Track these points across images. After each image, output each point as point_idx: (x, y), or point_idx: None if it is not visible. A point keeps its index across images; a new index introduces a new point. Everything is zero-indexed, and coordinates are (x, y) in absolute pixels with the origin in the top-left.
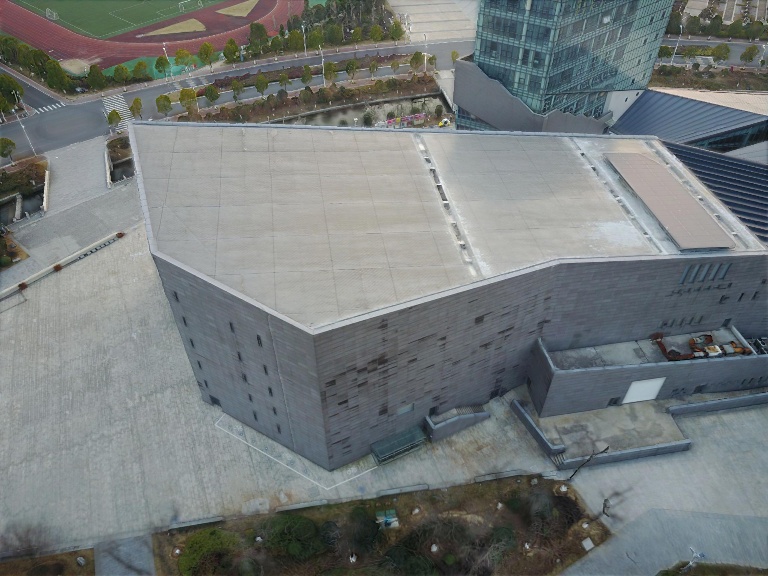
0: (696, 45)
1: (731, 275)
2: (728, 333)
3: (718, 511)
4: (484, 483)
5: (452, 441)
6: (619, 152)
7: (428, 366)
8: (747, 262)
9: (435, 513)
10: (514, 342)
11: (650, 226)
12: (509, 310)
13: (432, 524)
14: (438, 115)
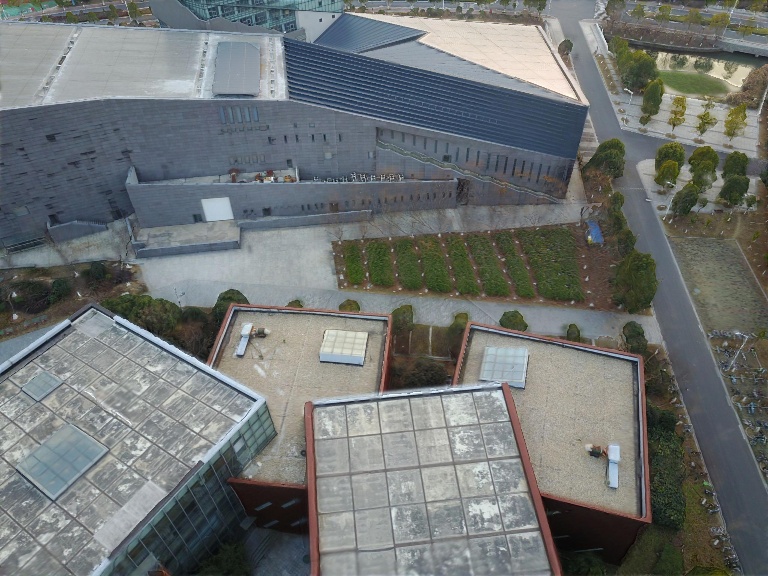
0: None
1: (263, 118)
2: (292, 172)
3: (234, 281)
4: (77, 264)
5: (71, 242)
6: None
7: (21, 173)
8: (269, 107)
9: (28, 278)
10: (106, 166)
11: (207, 83)
12: (79, 134)
13: (21, 283)
14: None
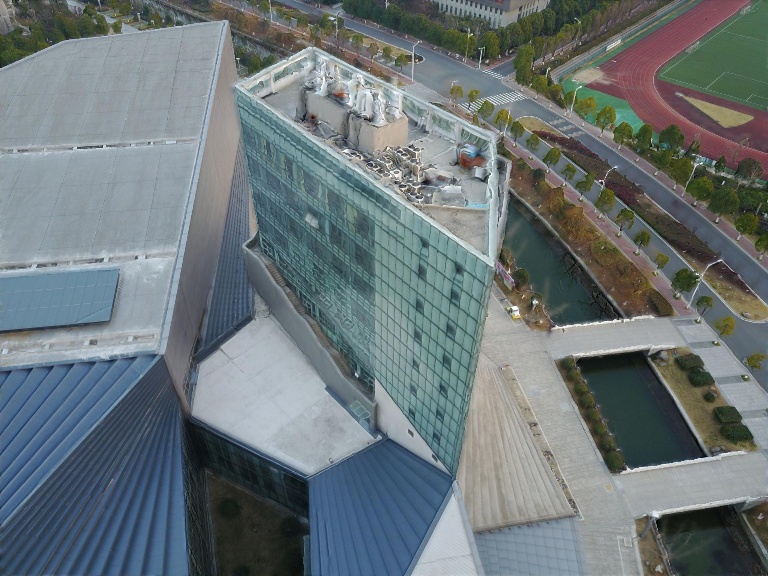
0: None
1: None
2: None
3: None
4: None
5: None
6: (128, 292)
7: None
8: None
9: None
10: None
11: None
12: None
13: None
14: None
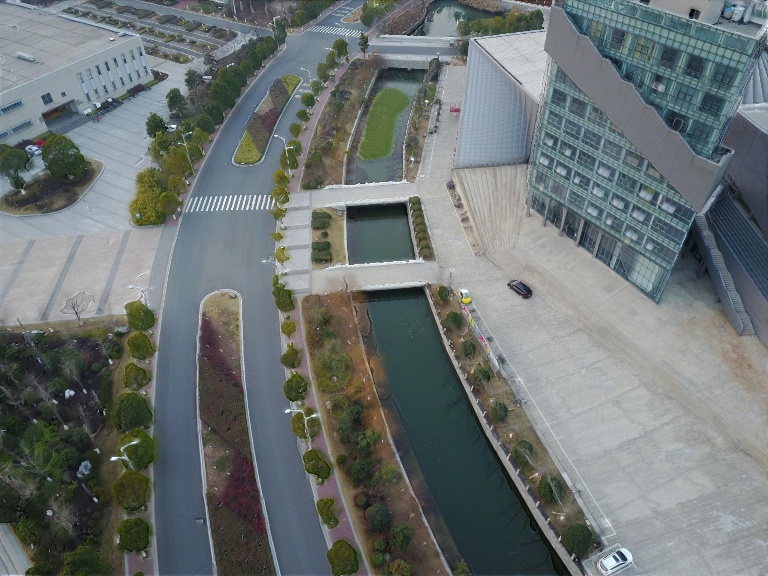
0: (275, 83)
1: None
2: None
3: None
4: None
5: None
6: None
7: None
8: None
9: None
10: None
11: None
12: None
13: None
14: (446, 299)
